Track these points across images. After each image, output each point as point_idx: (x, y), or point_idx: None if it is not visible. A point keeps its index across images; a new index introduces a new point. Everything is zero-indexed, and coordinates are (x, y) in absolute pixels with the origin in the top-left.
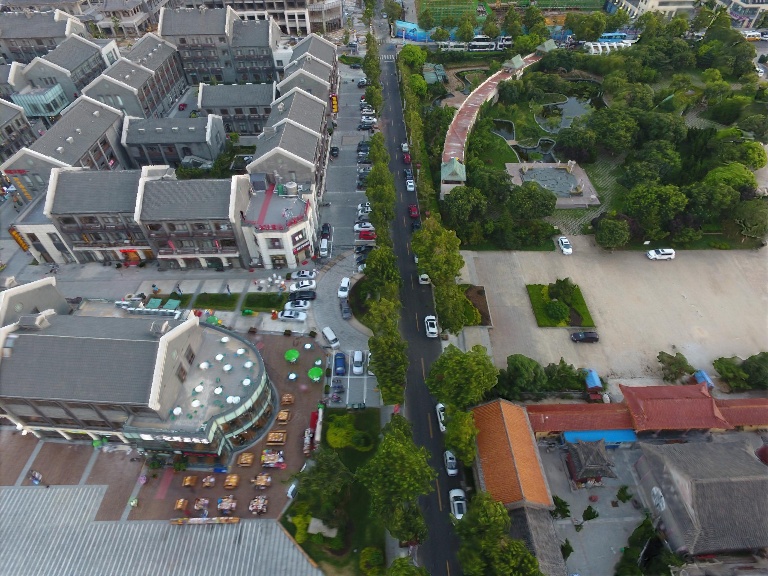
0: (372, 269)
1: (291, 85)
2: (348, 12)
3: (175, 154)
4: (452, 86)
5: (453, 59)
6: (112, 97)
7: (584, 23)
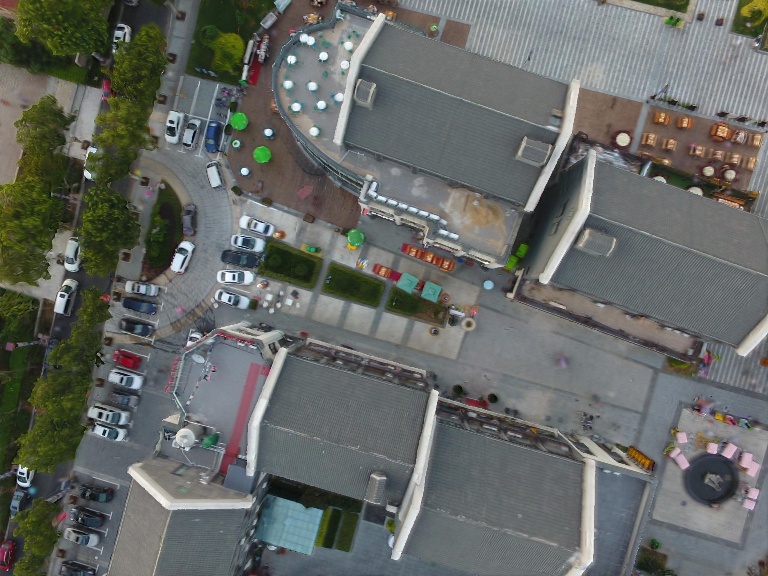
0: None
1: None
2: None
3: None
4: None
5: None
6: None
7: None
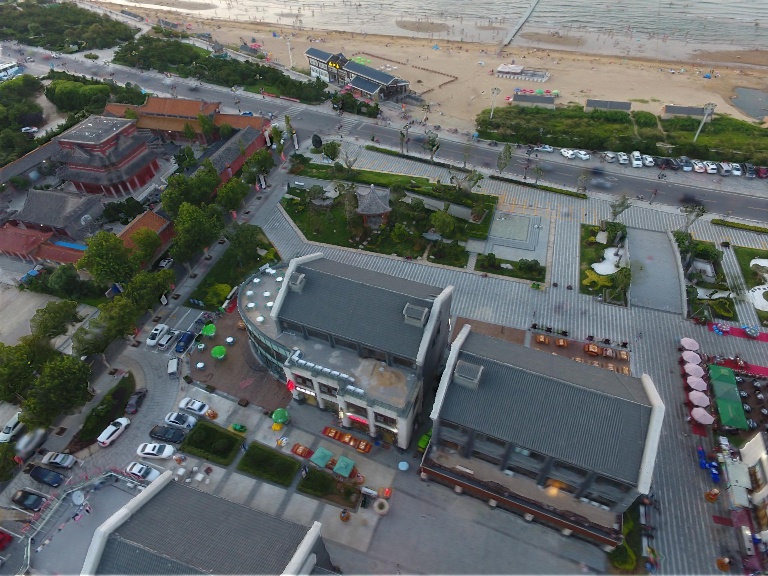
0: None
1: None
2: None
3: None
4: None
5: None
6: None
7: None
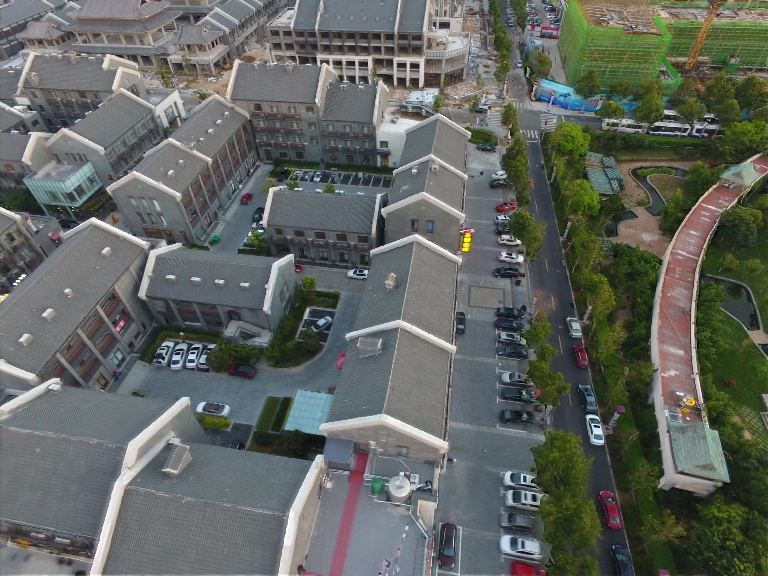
0: None
1: (404, 212)
2: (471, 55)
3: (216, 315)
4: (630, 196)
5: (626, 146)
6: (146, 200)
7: None
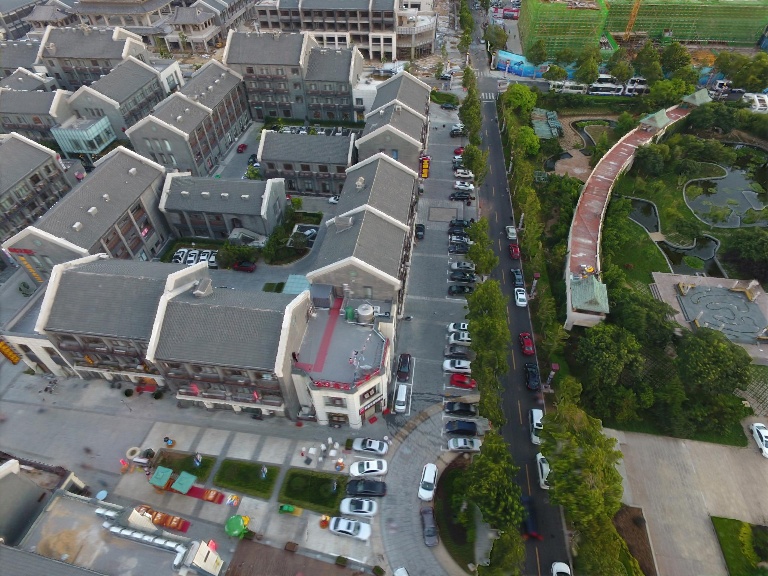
0: (481, 492)
1: (373, 143)
2: (440, 34)
3: (222, 224)
4: (568, 141)
5: (568, 104)
6: (159, 141)
7: (748, 69)
